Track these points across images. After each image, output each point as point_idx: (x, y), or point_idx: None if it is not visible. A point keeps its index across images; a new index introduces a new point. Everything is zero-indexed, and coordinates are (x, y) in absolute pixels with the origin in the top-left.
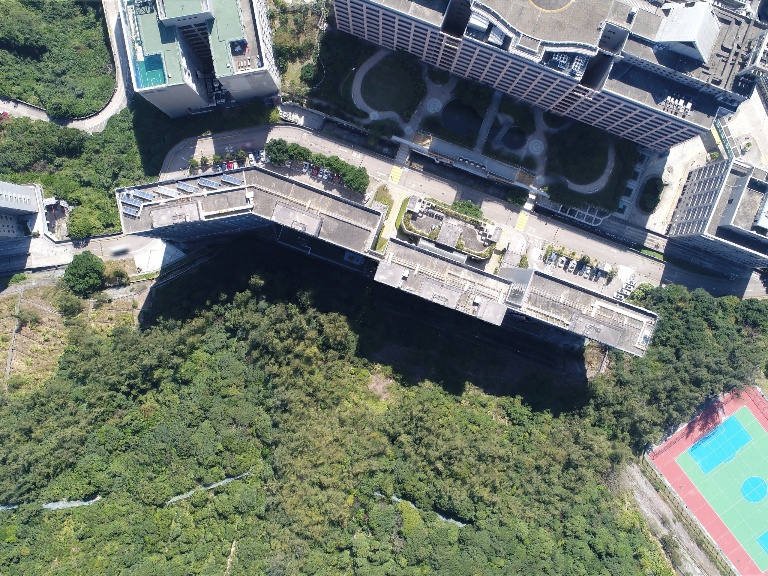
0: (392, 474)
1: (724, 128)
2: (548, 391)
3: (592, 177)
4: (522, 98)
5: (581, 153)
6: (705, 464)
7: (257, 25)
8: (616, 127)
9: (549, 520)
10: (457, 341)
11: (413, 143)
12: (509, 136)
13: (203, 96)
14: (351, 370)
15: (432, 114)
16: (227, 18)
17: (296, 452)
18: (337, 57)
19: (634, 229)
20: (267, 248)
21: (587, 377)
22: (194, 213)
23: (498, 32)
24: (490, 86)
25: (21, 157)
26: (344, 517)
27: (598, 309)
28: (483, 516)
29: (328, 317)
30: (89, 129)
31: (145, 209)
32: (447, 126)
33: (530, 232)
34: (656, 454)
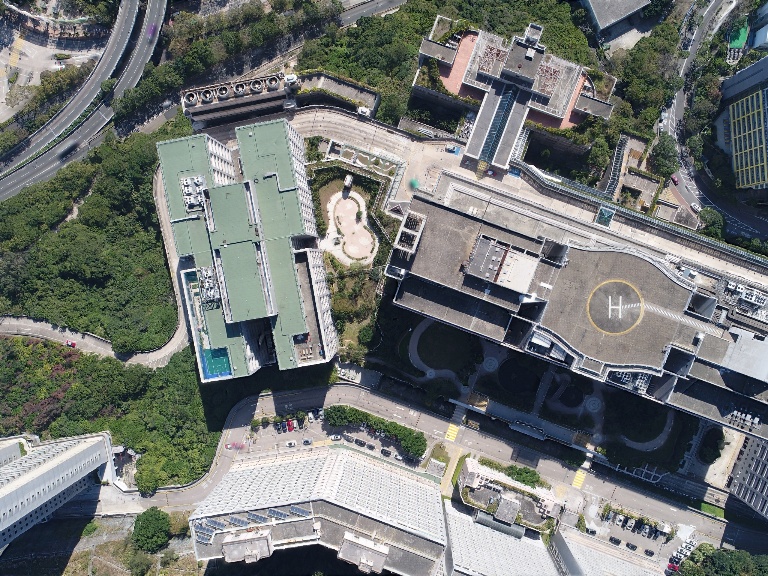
0: None
1: None
2: None
3: (651, 435)
4: None
5: (640, 419)
6: None
7: (319, 320)
8: None
9: None
10: None
11: (470, 406)
12: (566, 394)
13: (264, 360)
14: None
15: (488, 373)
16: (290, 313)
17: None
18: None
19: (694, 483)
20: None
21: None
22: (264, 549)
23: (560, 349)
24: None
25: (91, 405)
26: None
27: None
28: None
29: None
30: (152, 362)
31: (217, 536)
32: (503, 384)
33: (587, 490)
34: None
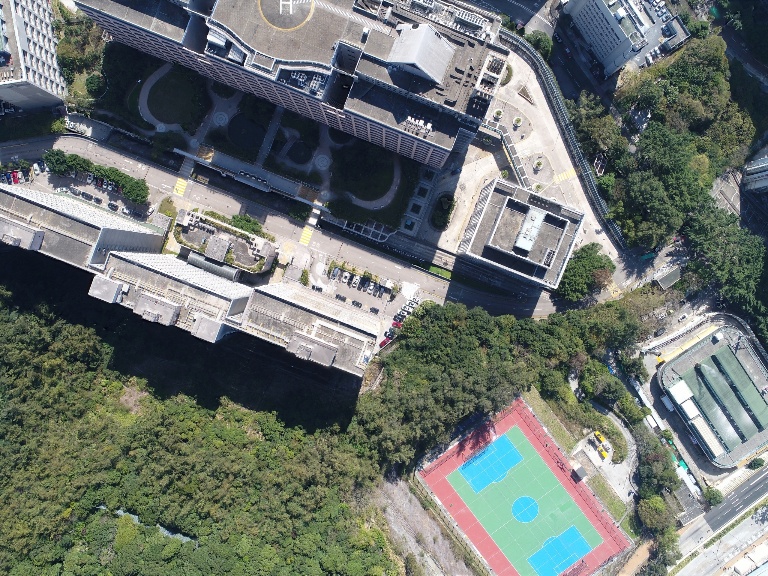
0: (121, 488)
1: (510, 147)
2: (307, 407)
3: (378, 193)
4: (301, 113)
5: (360, 169)
6: (476, 483)
7: (16, 37)
8: (388, 144)
9: (276, 537)
10: (224, 355)
11: (195, 156)
12: (295, 151)
13: None
14: (102, 382)
15: (218, 127)
16: None
17: (20, 464)
18: (119, 69)
19: (423, 246)
20: (48, 258)
21: (359, 393)
22: None
23: (237, 49)
24: (269, 101)
25: None
26: (52, 530)
27: (319, 328)
28: (205, 532)
29: (75, 329)
30: None
31: None
32: (233, 140)
33: (314, 247)
34: (426, 472)
